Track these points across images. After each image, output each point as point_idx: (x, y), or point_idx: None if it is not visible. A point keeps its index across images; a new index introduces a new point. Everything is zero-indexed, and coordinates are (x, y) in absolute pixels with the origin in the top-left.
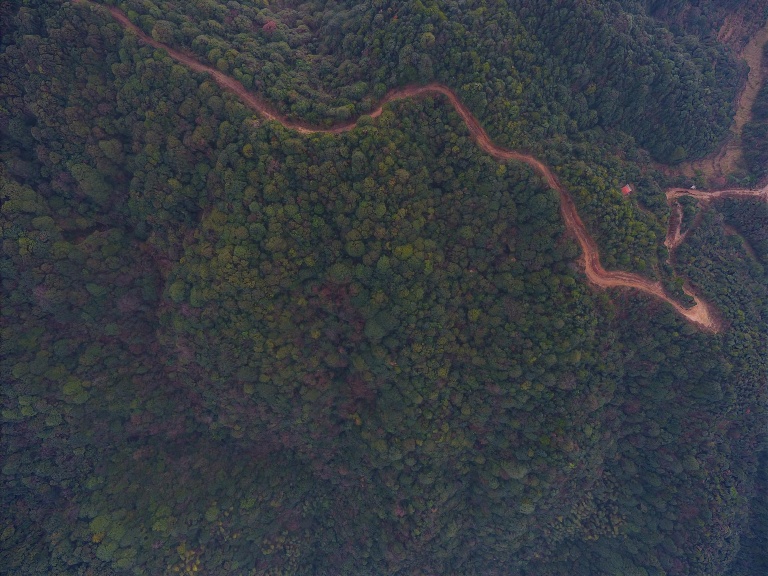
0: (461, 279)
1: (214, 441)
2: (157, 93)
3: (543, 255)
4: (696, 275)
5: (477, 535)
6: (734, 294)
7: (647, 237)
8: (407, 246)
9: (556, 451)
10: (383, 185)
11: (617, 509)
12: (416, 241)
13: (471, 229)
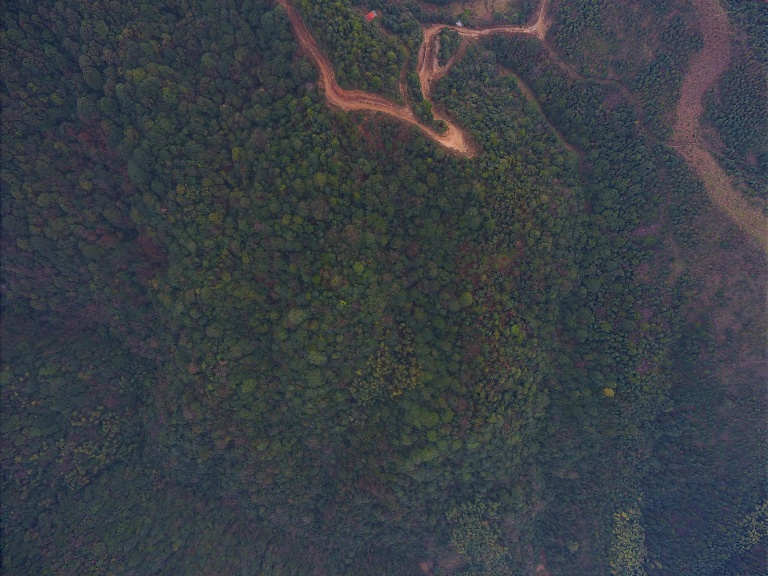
0: (219, 117)
1: (21, 317)
2: None
3: (284, 79)
4: (453, 104)
5: (286, 398)
6: (493, 123)
7: (386, 57)
8: (137, 69)
9: (328, 290)
10: None
11: (415, 360)
12: (148, 65)
13: (211, 56)
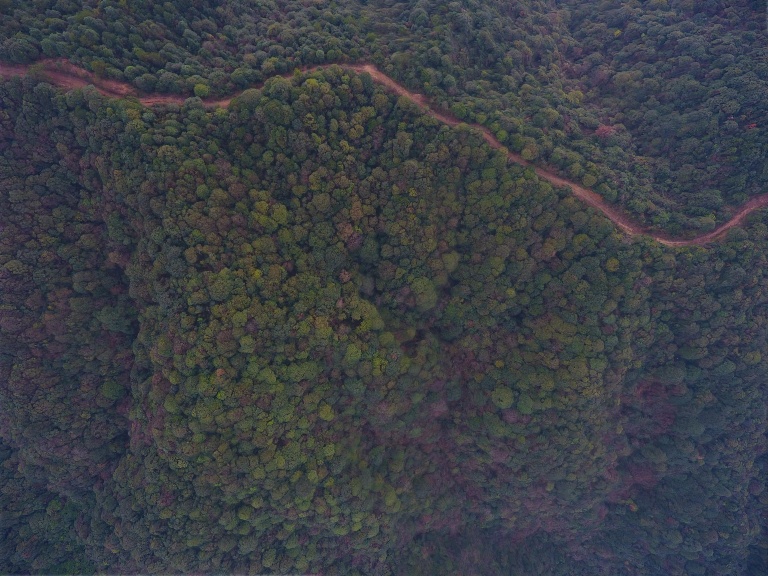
0: None
1: (476, 529)
2: (521, 210)
3: None
4: None
5: None
6: None
7: None
8: (758, 352)
9: None
10: (750, 296)
11: None
12: (765, 346)
13: None
